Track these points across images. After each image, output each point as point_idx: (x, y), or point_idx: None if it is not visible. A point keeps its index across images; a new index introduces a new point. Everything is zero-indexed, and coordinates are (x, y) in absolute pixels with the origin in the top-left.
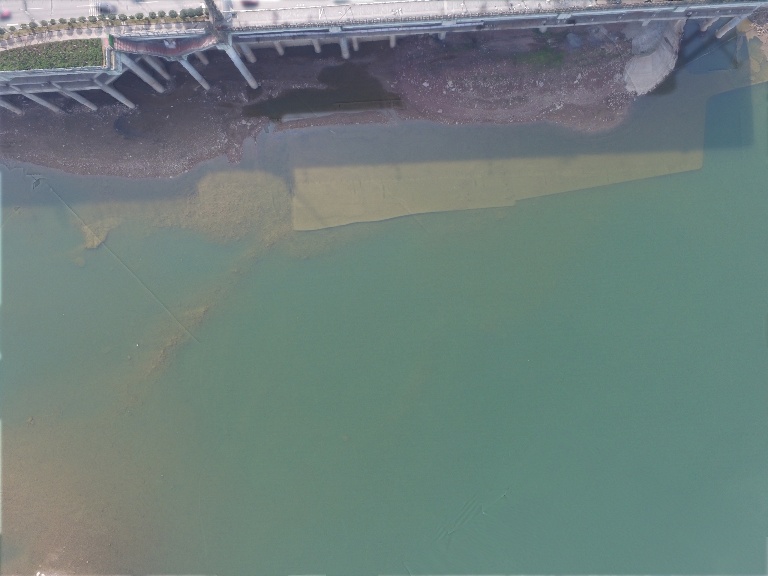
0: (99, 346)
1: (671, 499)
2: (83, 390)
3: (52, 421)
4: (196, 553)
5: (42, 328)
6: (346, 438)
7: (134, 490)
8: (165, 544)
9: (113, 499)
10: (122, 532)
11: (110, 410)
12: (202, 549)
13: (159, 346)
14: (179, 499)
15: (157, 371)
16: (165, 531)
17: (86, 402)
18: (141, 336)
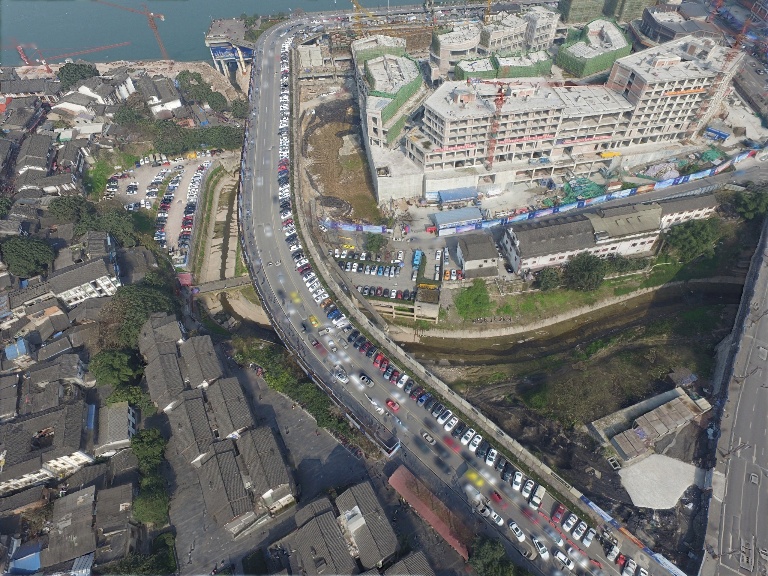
0: None
1: None
2: None
3: None
4: None
5: None
6: None
7: None
8: None
9: None
10: None
11: None
12: None
13: None
14: None
15: (448, 0)
16: None
17: None
18: None
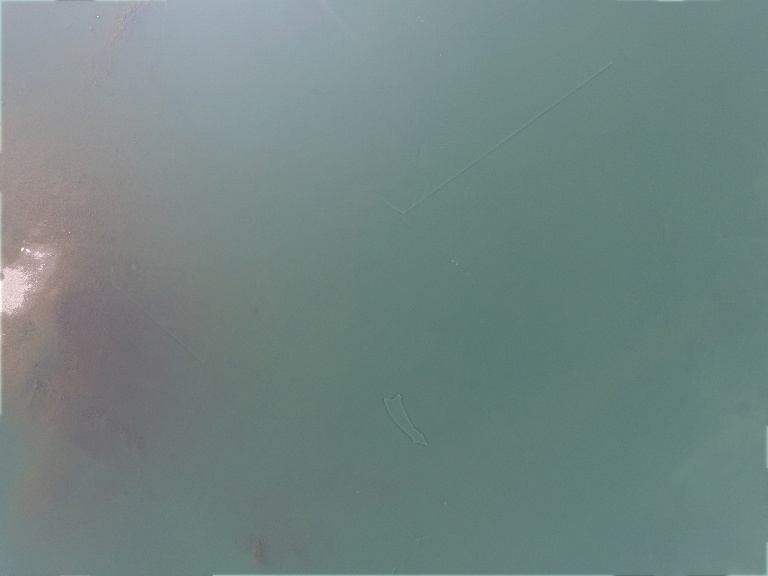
0: (60, 21)
1: (621, 2)
2: (49, 66)
3: (21, 99)
4: (176, 216)
5: (3, 16)
6: (312, 86)
7: (109, 160)
8: (144, 210)
9: (89, 170)
10: (101, 201)
11: (77, 83)
12: (181, 211)
13: (119, 15)
14: (154, 164)
15: (120, 39)
16: (143, 197)
17: (53, 78)
18: (100, 7)
